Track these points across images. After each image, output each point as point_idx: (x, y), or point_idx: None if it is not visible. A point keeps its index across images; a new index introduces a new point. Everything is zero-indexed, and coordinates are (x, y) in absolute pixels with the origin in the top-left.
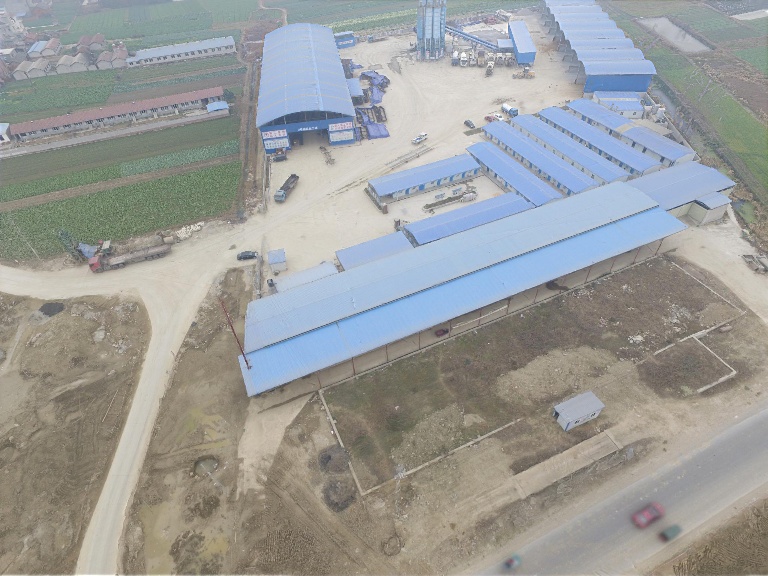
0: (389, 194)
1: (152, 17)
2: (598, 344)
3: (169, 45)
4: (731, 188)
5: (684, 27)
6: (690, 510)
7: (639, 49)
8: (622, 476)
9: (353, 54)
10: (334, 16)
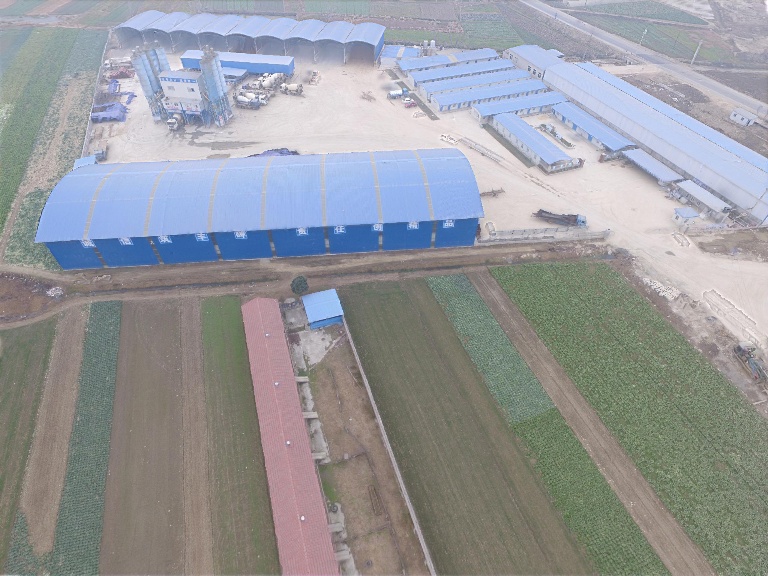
0: None
1: None
2: None
3: None
4: None
5: (238, 12)
6: (767, 108)
7: (338, 21)
8: None
9: None
10: None
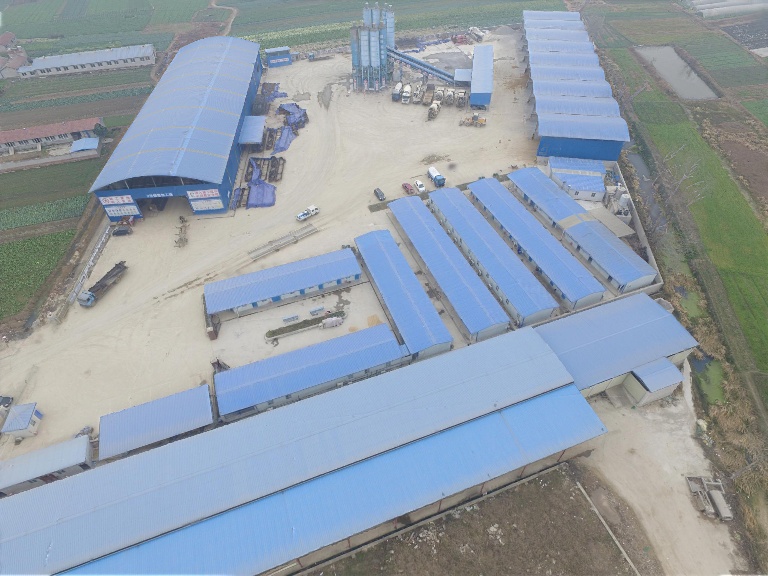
0: None
1: (87, 11)
2: None
3: None
4: (691, 348)
5: (690, 62)
6: None
7: (616, 101)
8: None
9: (284, 76)
10: (285, 22)
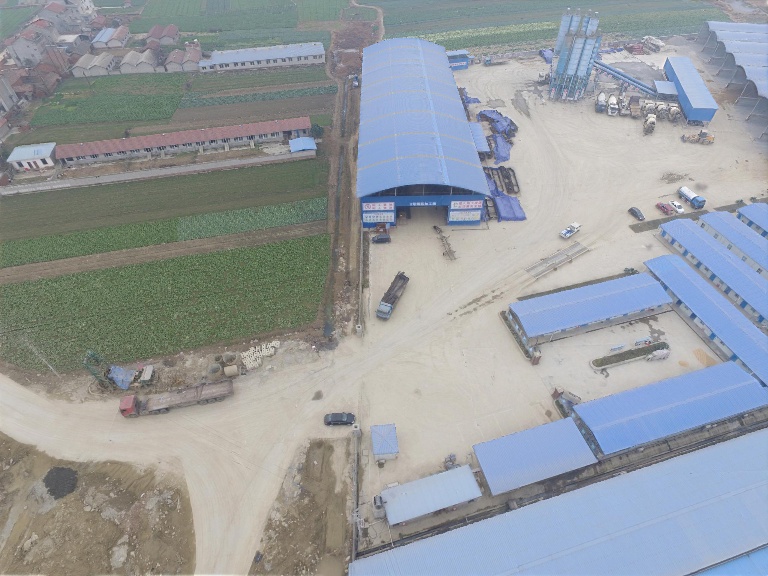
0: None
1: (232, 6)
2: None
3: (249, 48)
4: None
5: None
6: None
7: None
8: None
9: (466, 81)
10: (440, 24)
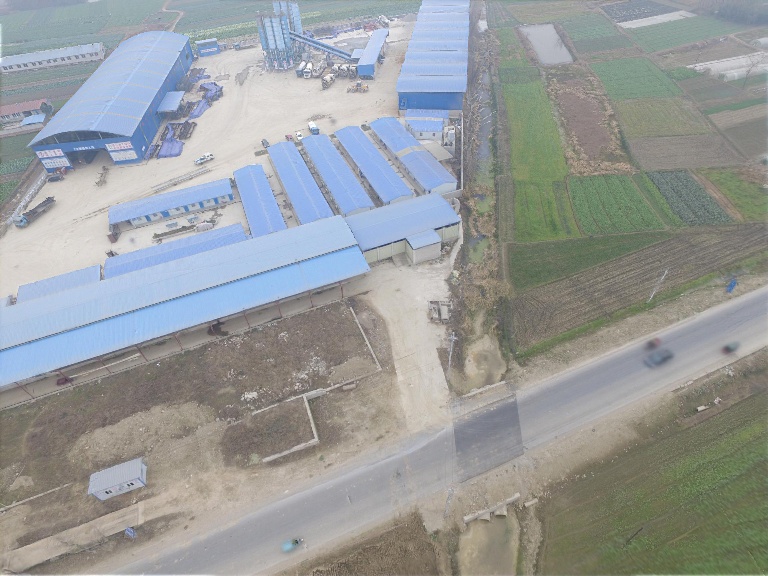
0: (126, 221)
1: (51, 20)
2: (208, 400)
3: None
4: (457, 224)
5: (561, 35)
6: None
7: (467, 64)
8: (121, 556)
9: (211, 63)
10: (223, 20)
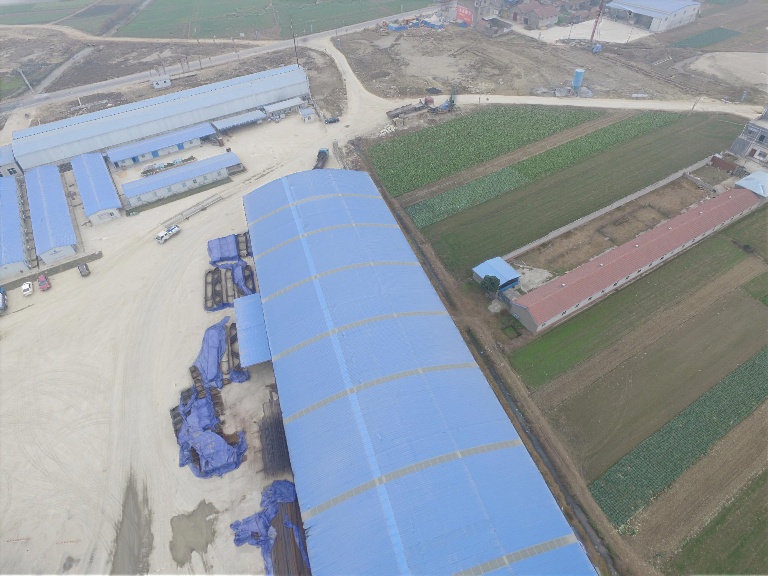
0: None
1: None
2: None
3: None
4: None
5: None
6: None
7: None
8: None
9: None
10: None
